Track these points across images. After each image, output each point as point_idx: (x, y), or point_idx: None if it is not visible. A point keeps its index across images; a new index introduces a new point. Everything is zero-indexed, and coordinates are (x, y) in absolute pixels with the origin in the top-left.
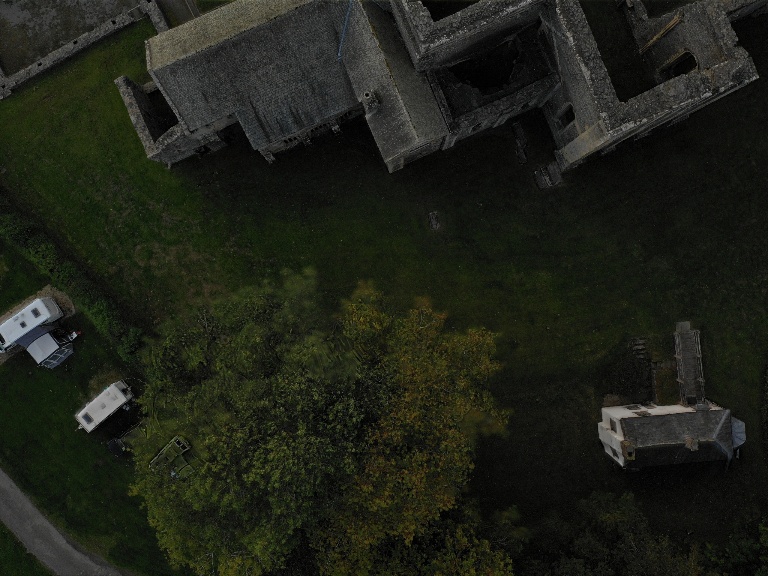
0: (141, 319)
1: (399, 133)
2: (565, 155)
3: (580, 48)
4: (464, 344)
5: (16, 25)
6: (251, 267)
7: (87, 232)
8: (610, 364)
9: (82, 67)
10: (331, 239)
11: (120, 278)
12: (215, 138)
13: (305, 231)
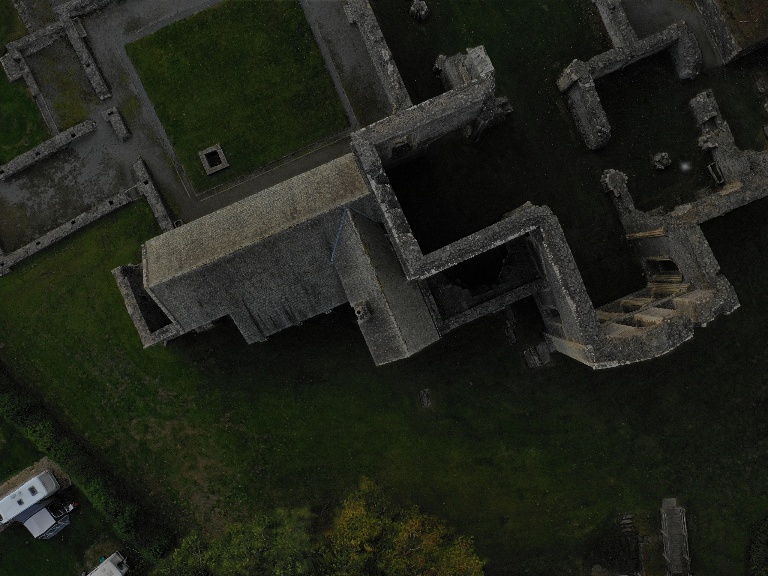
0: (137, 491)
1: (390, 344)
2: (553, 342)
3: (566, 282)
4: (452, 573)
5: (15, 204)
6: (245, 443)
7: (84, 406)
8: (598, 538)
9: (80, 245)
10: (324, 416)
11: (116, 451)
12: (210, 326)
13: (298, 408)
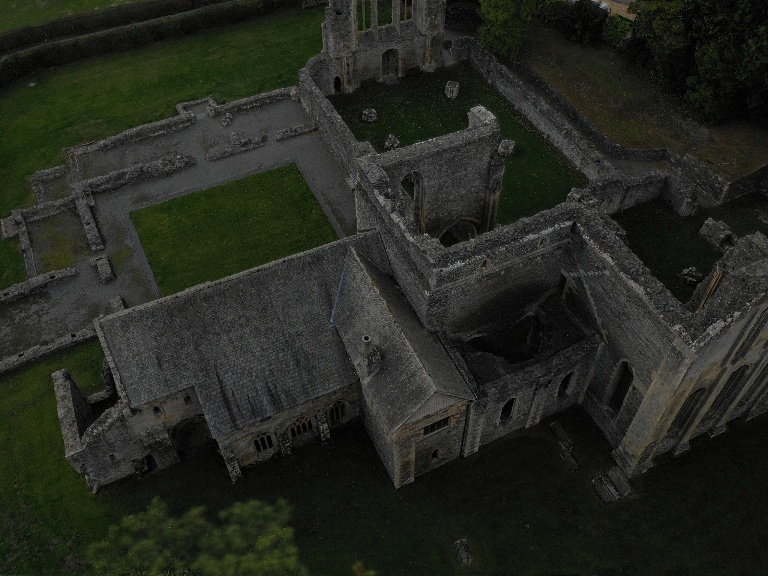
0: None
1: (409, 388)
2: (629, 447)
3: (623, 266)
4: None
5: None
6: None
7: None
8: None
9: (20, 381)
10: None
11: None
12: (164, 437)
13: (274, 574)
